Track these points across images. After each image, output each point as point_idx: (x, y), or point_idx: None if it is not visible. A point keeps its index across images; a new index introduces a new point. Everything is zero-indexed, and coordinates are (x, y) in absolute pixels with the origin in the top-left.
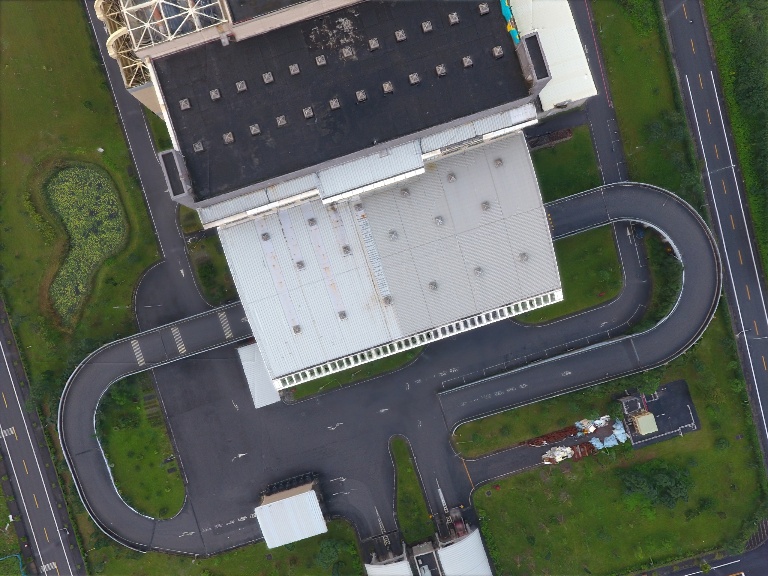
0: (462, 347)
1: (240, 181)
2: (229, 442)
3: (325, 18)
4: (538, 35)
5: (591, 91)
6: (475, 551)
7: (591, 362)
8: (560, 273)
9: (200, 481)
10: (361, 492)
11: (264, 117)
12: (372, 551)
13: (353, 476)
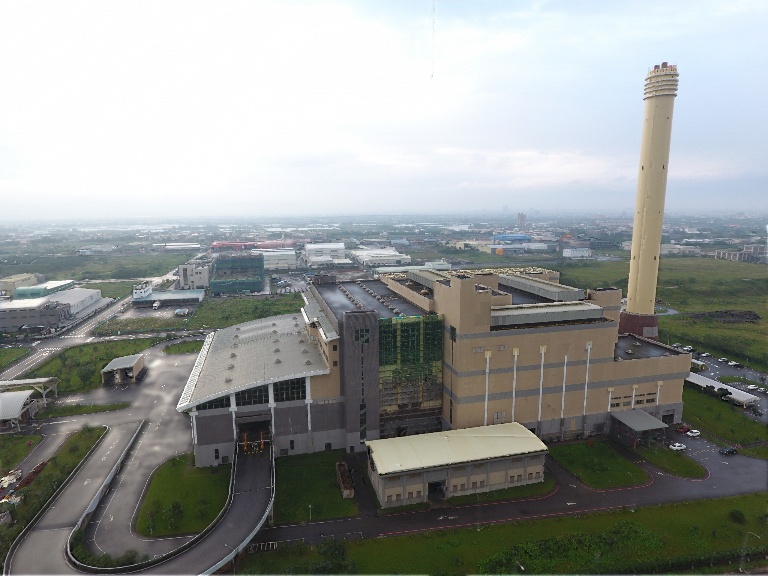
0: (172, 432)
1: (318, 288)
2: (188, 362)
3: (398, 296)
4: (376, 312)
5: (382, 468)
6: (6, 409)
7: (81, 497)
8: (197, 486)
9: (174, 356)
10: (107, 394)
11: (348, 290)
12: (60, 397)
13: (121, 392)
